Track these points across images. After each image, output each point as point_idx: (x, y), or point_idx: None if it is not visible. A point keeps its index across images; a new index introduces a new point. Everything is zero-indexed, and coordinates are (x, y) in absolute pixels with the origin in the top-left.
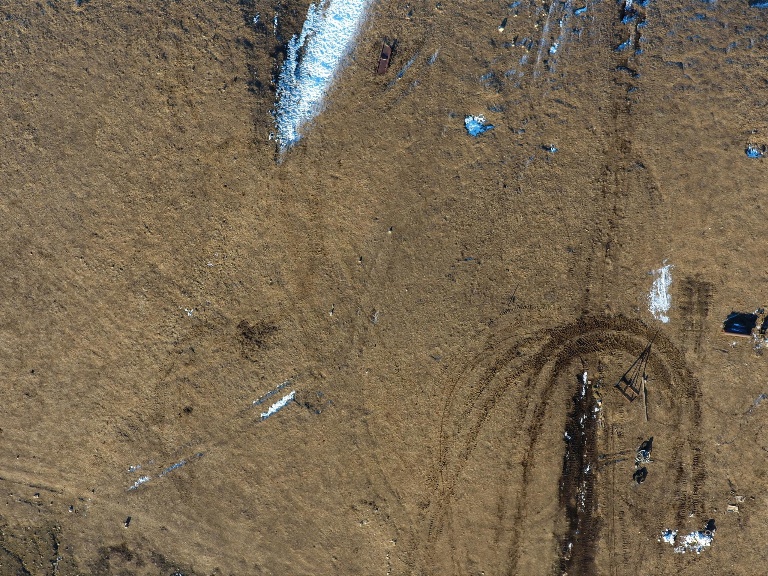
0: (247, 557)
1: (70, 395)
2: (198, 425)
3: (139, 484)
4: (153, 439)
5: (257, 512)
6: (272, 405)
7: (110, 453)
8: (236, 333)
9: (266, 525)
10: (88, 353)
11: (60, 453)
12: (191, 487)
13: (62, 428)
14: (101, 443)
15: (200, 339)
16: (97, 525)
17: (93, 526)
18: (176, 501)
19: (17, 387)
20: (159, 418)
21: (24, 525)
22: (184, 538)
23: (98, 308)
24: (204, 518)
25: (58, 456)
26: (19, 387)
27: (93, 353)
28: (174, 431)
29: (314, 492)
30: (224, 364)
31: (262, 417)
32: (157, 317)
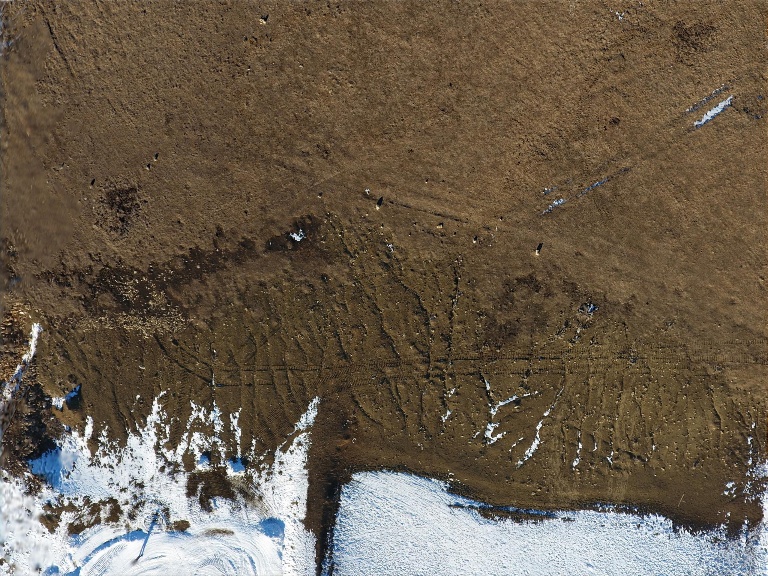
0: (667, 281)
1: (488, 110)
2: (625, 138)
3: (554, 207)
4: (573, 156)
5: (683, 230)
6: (707, 112)
7: (524, 175)
8: (671, 35)
9: (691, 244)
10: (511, 62)
11: (470, 177)
12: (613, 206)
13: (476, 148)
14: (515, 164)
15: (631, 44)
16: (503, 255)
17: (499, 257)
18: (595, 222)
19: (433, 103)
20: (581, 133)
21: (425, 258)
22: (601, 263)
23: (526, 12)
24: (624, 240)
25: (467, 180)
26: (435, 103)
27: (517, 62)
28: (598, 146)
29: (746, 206)
30: (657, 70)
31: (696, 126)
32: (587, 21)
